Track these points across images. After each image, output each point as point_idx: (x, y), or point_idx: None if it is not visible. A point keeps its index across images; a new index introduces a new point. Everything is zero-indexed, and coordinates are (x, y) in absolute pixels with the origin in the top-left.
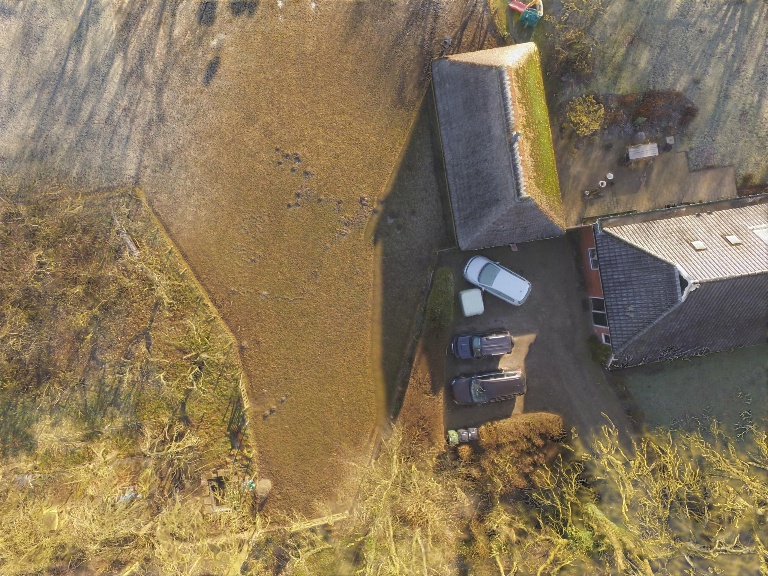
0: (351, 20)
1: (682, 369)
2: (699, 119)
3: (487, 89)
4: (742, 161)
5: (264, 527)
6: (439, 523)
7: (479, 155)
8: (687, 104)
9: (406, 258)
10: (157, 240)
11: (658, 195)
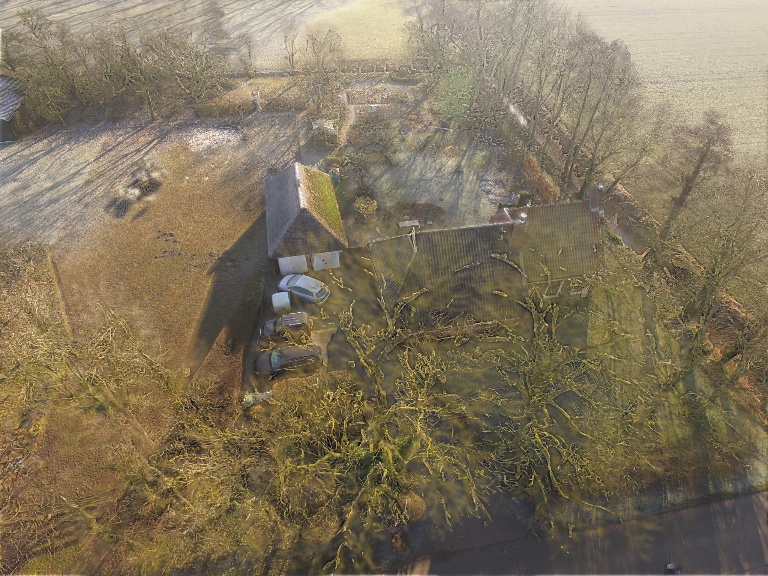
0: (228, 182)
1: (469, 350)
2: (447, 214)
3: (288, 175)
4: None
5: (8, 518)
6: None
7: (282, 204)
8: None
9: (236, 283)
10: (44, 275)
11: None
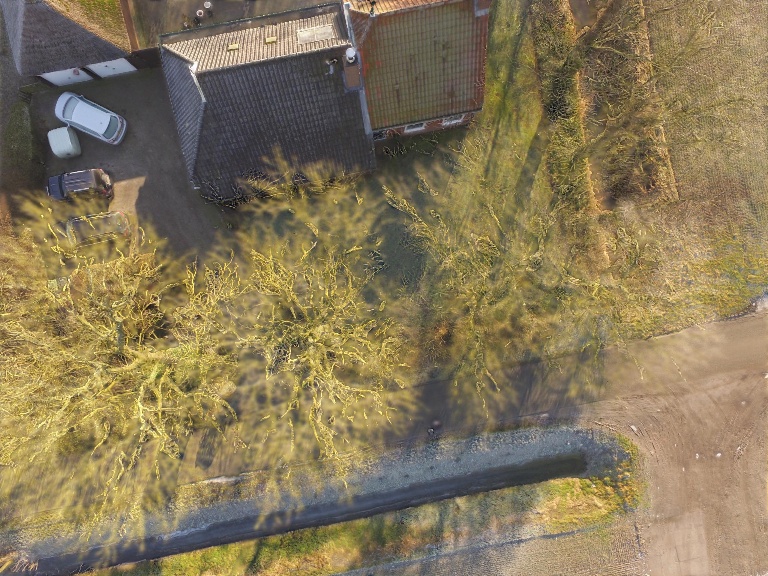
0: None
1: (303, 208)
2: None
3: None
4: None
5: None
6: (60, 379)
7: None
8: None
9: (1, 101)
10: None
11: None
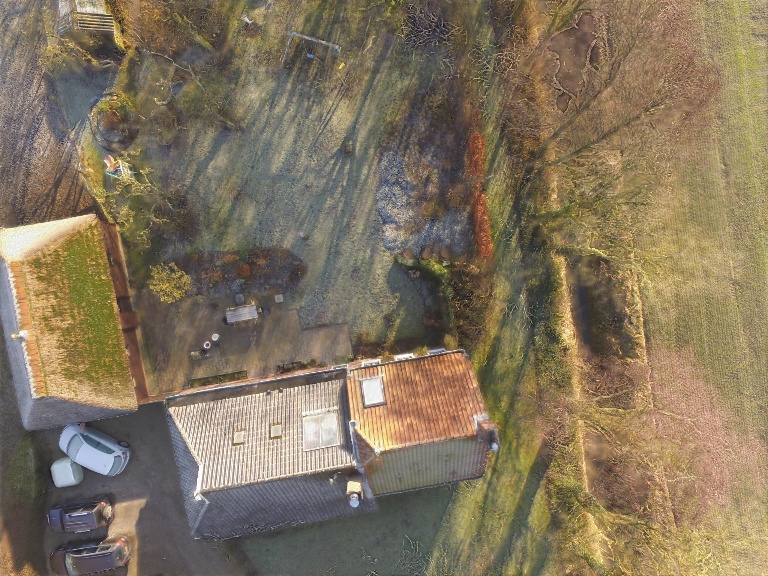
0: None
1: (302, 531)
2: (309, 276)
3: (5, 281)
4: (355, 318)
5: None
6: None
7: (14, 343)
8: (294, 262)
9: (5, 424)
10: None
11: (269, 354)
